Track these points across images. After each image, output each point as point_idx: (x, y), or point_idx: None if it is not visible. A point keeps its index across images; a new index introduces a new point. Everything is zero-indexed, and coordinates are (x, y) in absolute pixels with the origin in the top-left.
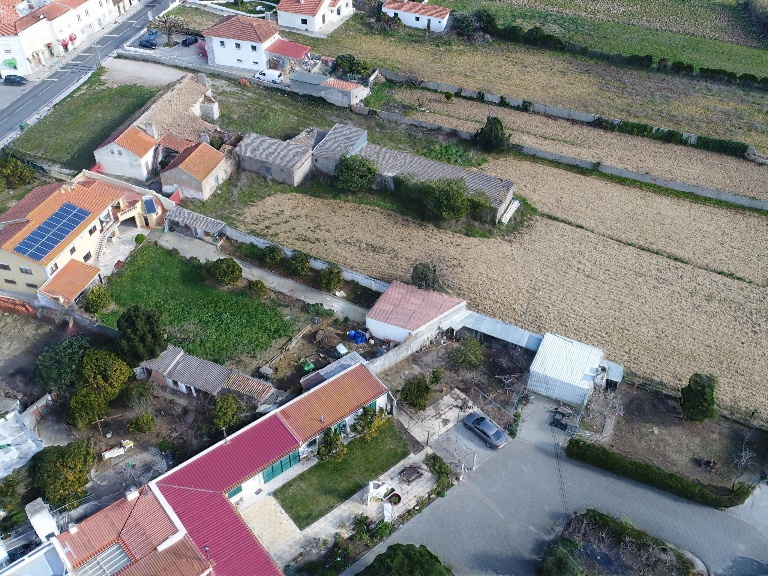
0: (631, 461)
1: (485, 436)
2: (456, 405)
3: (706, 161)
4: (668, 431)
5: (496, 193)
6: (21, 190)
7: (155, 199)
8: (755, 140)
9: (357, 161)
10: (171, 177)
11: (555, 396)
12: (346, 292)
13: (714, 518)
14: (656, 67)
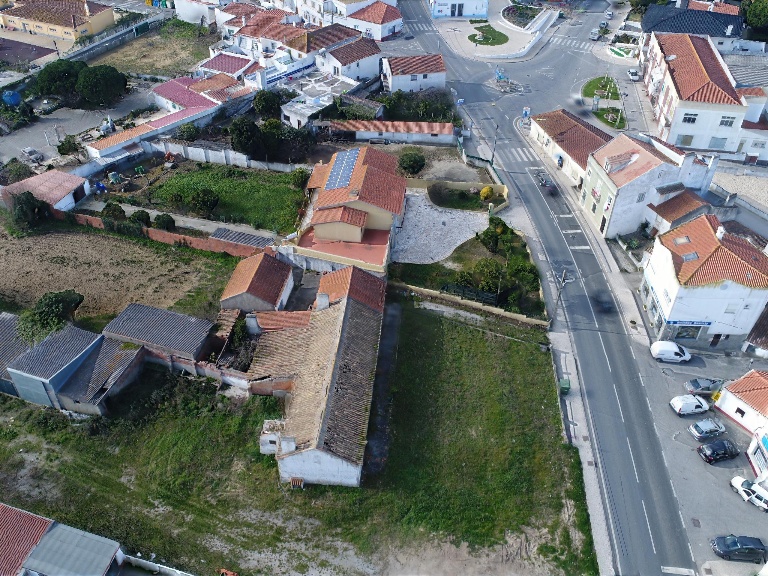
0: None
1: None
2: None
3: None
4: None
5: None
6: None
7: None
8: None
9: (44, 306)
10: None
11: None
12: None
13: None
14: None
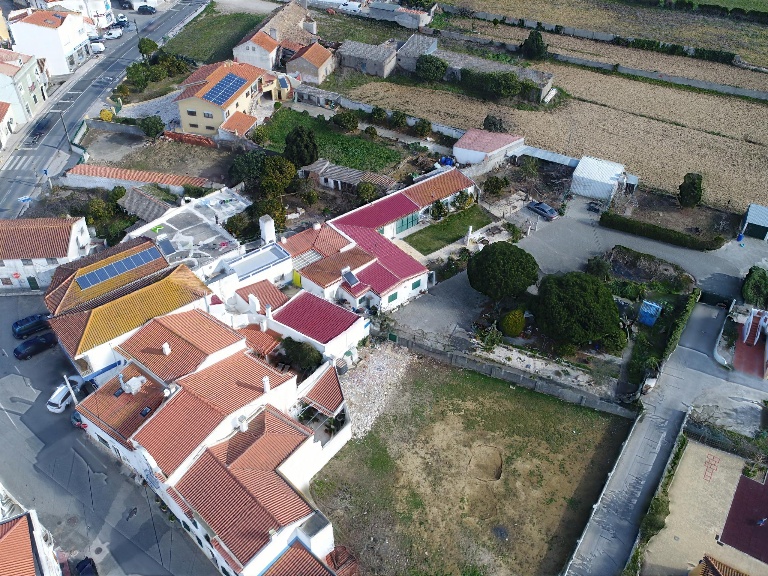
0: (644, 223)
1: (543, 212)
2: (521, 199)
3: (702, 66)
4: (670, 215)
5: (540, 80)
6: (178, 78)
7: (286, 79)
8: (741, 53)
9: (433, 57)
10: (295, 65)
11: (590, 195)
12: (434, 139)
13: (700, 255)
14: (663, 5)
